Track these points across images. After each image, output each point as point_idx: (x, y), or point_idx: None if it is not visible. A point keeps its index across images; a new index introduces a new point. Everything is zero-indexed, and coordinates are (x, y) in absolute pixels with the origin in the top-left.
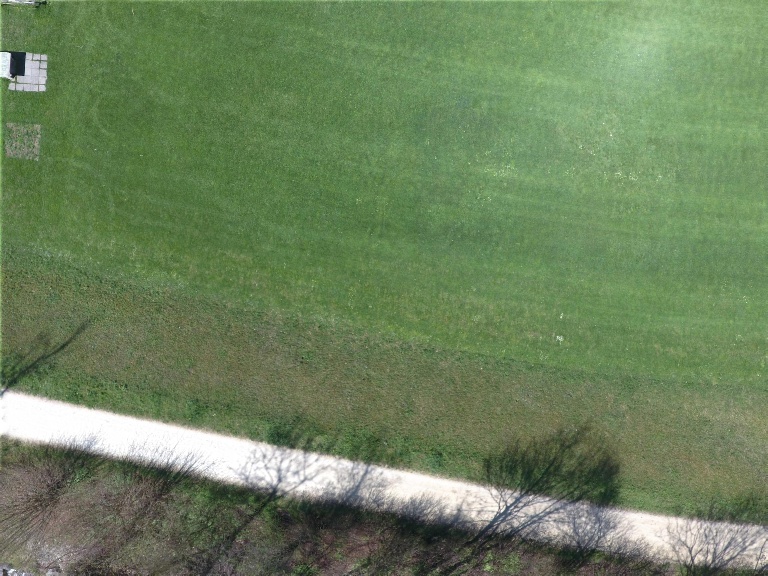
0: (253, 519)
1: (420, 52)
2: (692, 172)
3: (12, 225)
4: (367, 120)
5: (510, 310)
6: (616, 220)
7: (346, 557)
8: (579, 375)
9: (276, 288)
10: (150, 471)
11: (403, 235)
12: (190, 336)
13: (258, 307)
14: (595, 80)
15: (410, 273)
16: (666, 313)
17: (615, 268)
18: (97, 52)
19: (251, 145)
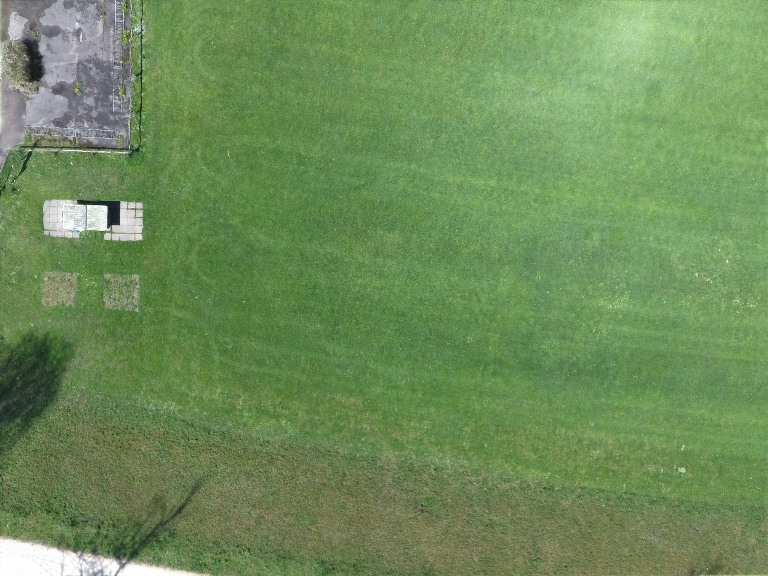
0: None
1: (528, 185)
2: None
3: (114, 378)
4: (475, 256)
5: (629, 444)
6: (735, 348)
7: None
8: (703, 507)
9: (388, 431)
10: None
11: (517, 372)
12: (306, 489)
13: (371, 452)
14: (709, 206)
15: (525, 410)
16: None
17: (736, 397)
18: (193, 197)
19: (356, 286)
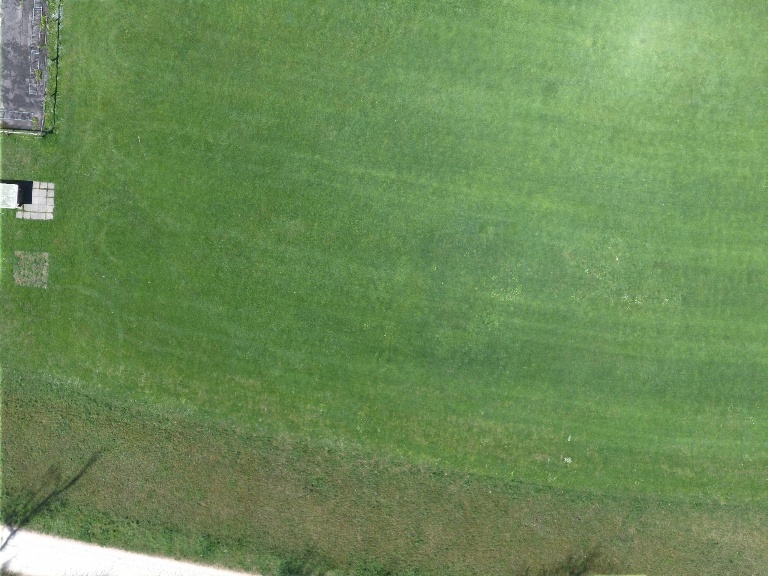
0: None
1: (426, 178)
2: (698, 295)
3: (21, 352)
4: (374, 245)
5: (518, 433)
6: (623, 343)
7: None
8: (587, 497)
9: (285, 412)
10: None
11: (411, 359)
12: (200, 465)
13: (267, 432)
14: (600, 205)
15: (418, 397)
16: (673, 435)
17: (622, 391)
18: (104, 180)
19: (258, 271)
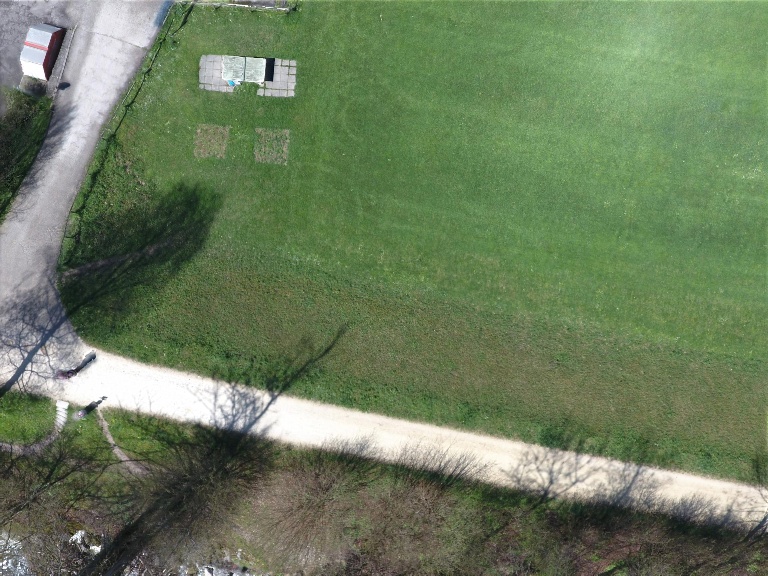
0: (514, 521)
1: (668, 57)
2: None
3: (260, 230)
4: (614, 124)
5: (757, 311)
6: None
7: (602, 559)
8: None
9: (523, 291)
10: (423, 474)
11: (651, 238)
12: (447, 339)
13: (507, 310)
14: None
15: (657, 275)
16: None
17: None
18: (345, 58)
19: (499, 149)
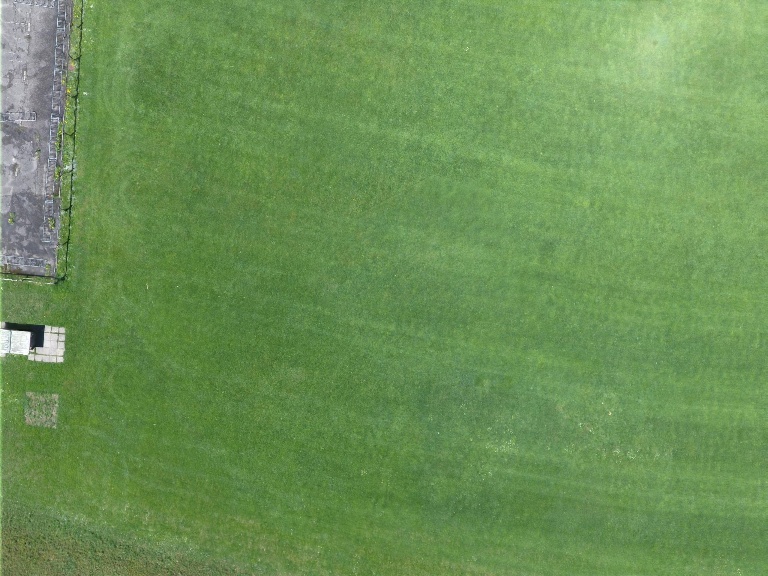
0: None
1: (424, 332)
2: (689, 451)
3: (31, 489)
4: (372, 395)
5: None
6: (614, 496)
7: None
8: None
9: (283, 553)
10: None
11: (406, 506)
12: None
13: (266, 572)
14: (594, 362)
15: (413, 542)
16: None
17: (612, 542)
18: (113, 325)
19: (260, 416)
